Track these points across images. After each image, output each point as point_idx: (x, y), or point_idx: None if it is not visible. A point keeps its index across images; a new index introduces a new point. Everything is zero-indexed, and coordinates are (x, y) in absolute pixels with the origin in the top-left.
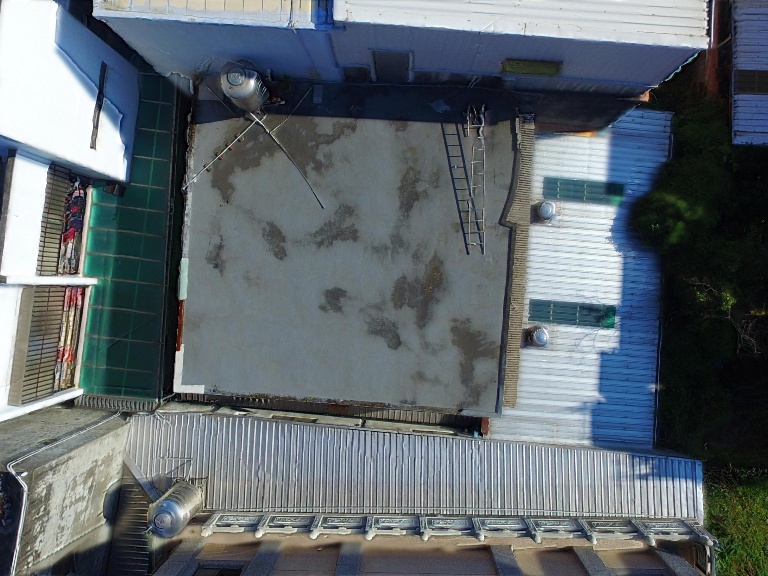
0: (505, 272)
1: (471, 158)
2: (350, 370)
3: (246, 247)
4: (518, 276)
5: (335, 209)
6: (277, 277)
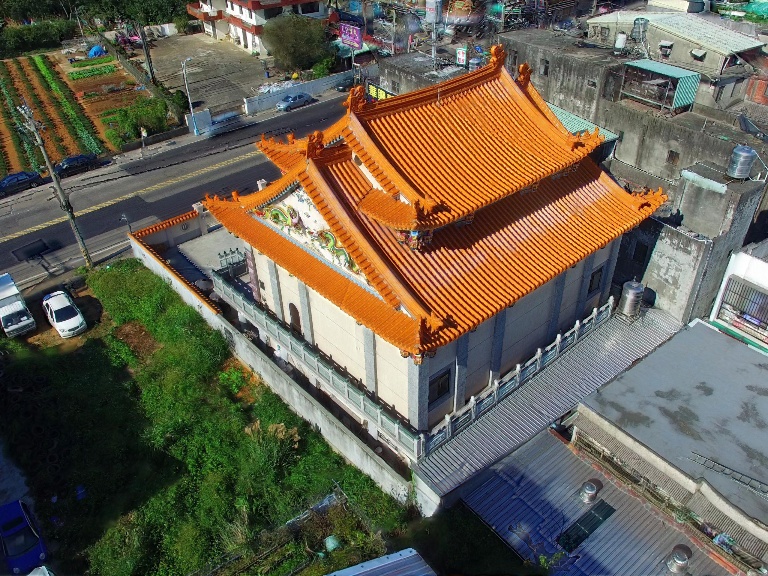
0: (667, 459)
1: (763, 496)
2: (658, 371)
3: (765, 380)
4: (655, 475)
5: (766, 422)
6: (737, 379)
